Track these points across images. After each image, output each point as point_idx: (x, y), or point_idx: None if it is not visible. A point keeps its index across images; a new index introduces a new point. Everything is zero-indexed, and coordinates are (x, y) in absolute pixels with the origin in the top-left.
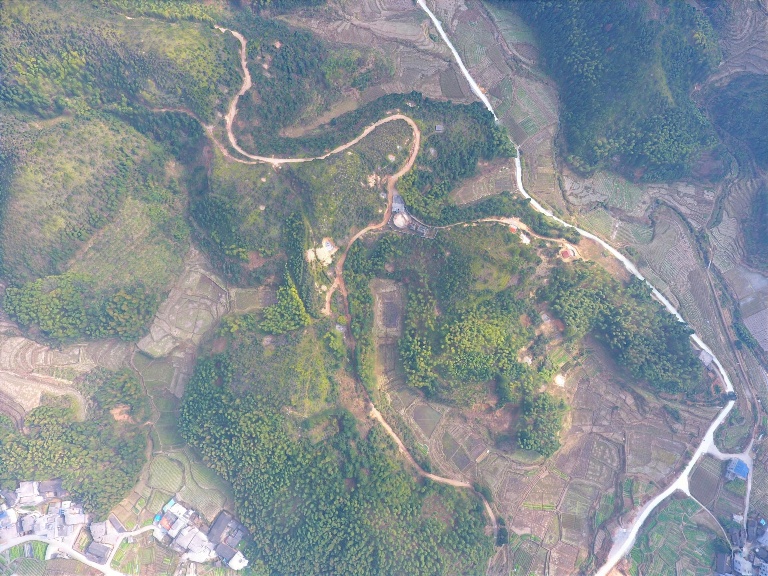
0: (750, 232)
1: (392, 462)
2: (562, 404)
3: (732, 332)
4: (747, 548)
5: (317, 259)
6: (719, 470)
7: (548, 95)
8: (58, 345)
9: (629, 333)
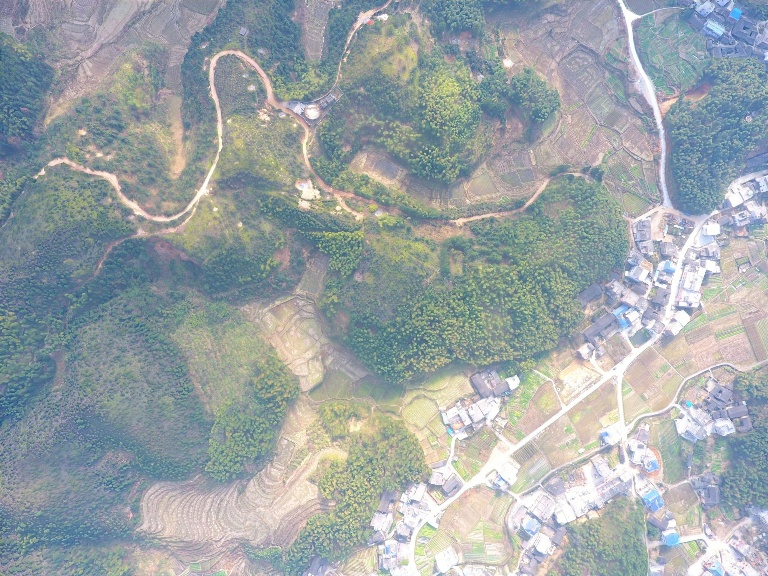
0: None
1: (504, 225)
2: (528, 71)
3: None
4: None
5: (310, 201)
6: None
7: None
8: (272, 454)
9: None
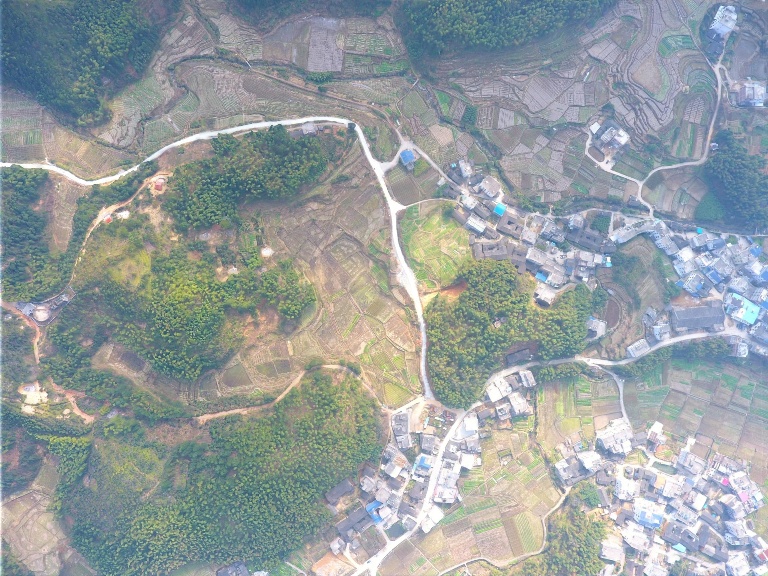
0: (238, 12)
1: (242, 428)
2: (282, 264)
3: (311, 86)
4: (465, 189)
5: (35, 405)
6: (402, 172)
7: (11, 100)
8: None
9: (251, 179)
